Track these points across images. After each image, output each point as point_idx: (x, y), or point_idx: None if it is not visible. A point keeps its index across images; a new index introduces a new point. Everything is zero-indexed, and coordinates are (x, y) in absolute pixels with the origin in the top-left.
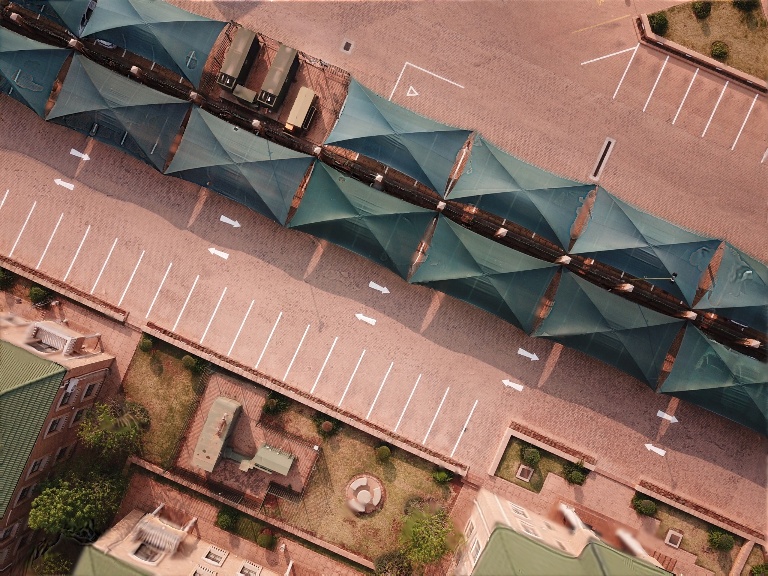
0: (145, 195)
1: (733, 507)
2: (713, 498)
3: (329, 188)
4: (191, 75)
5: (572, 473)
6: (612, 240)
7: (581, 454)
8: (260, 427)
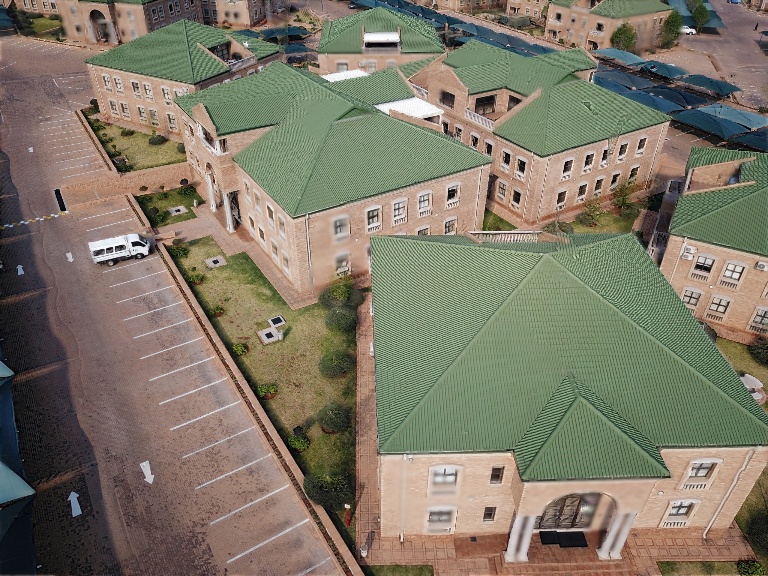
0: None
1: None
2: None
3: None
4: None
5: (427, 6)
6: (383, 4)
7: None
8: None
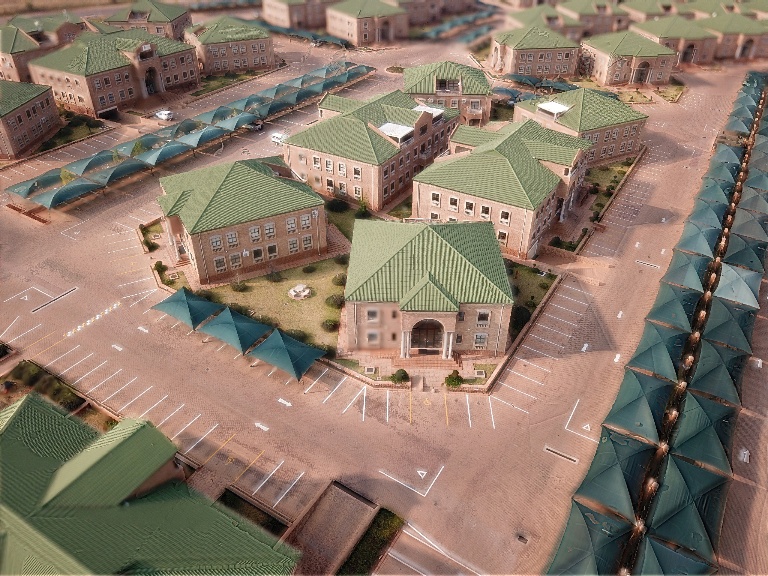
0: None
1: None
2: None
3: (766, 130)
4: None
5: None
6: None
7: None
8: None
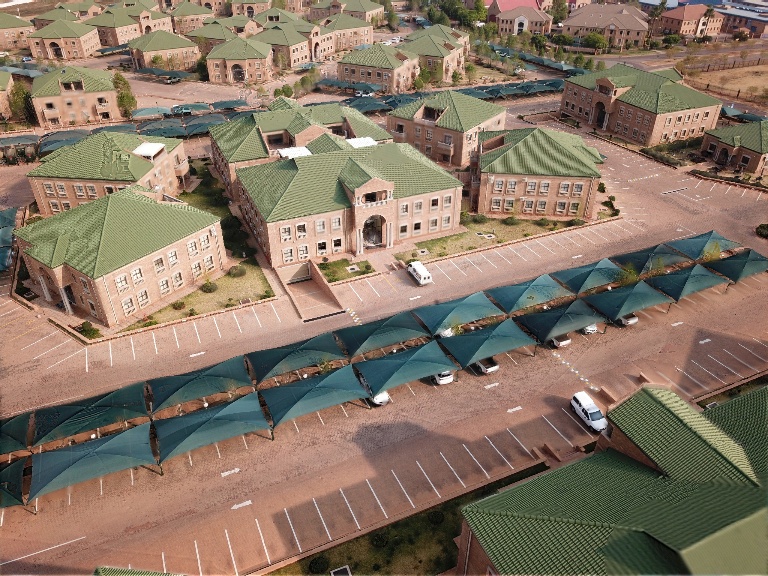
0: None
1: None
2: None
3: None
4: (43, 143)
5: None
6: None
7: None
8: None
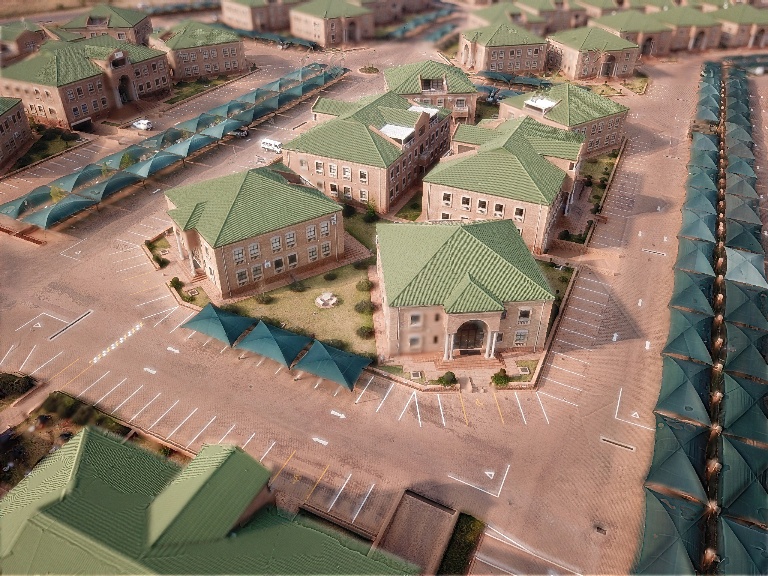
0: (761, 157)
1: (767, 90)
2: (767, 92)
3: None
4: None
5: None
6: None
7: None
8: None
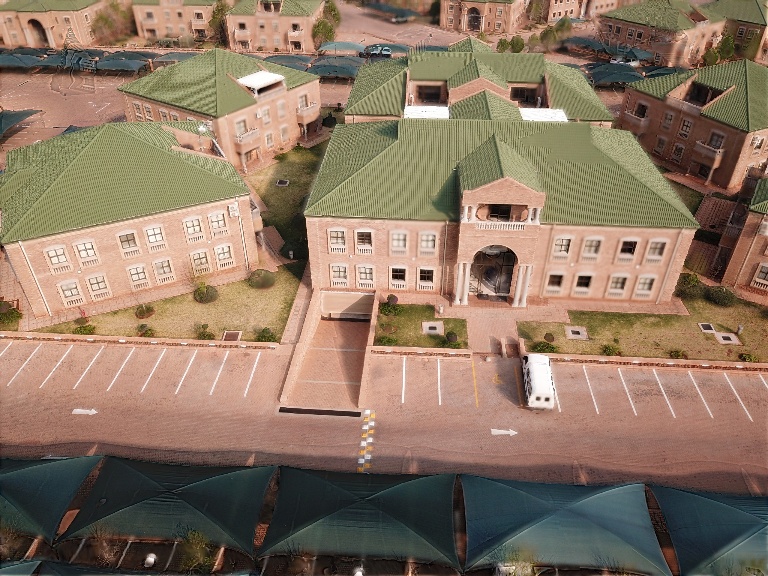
0: None
1: None
2: None
3: None
4: None
5: None
6: (25, 57)
7: (47, 52)
8: (173, 47)
